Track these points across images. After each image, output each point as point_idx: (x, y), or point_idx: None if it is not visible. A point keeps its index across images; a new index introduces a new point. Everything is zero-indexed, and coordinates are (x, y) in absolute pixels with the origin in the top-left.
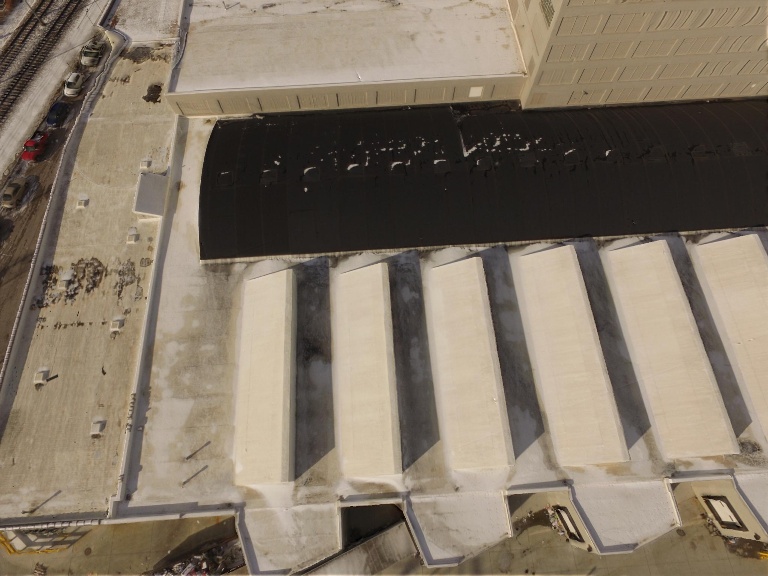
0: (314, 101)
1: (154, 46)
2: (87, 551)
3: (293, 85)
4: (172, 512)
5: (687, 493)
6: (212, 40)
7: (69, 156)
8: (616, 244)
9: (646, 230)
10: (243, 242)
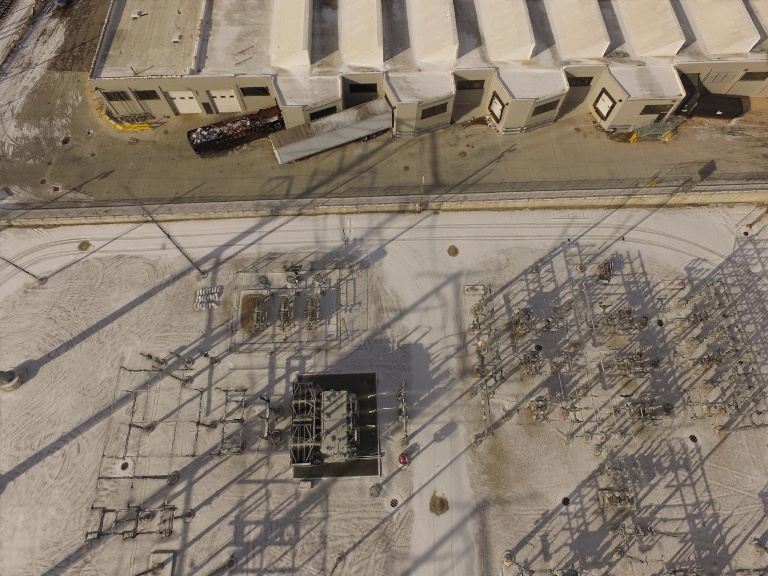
0: None
1: None
2: (166, 132)
3: None
4: None
5: (584, 110)
6: None
7: None
8: None
9: None
10: None
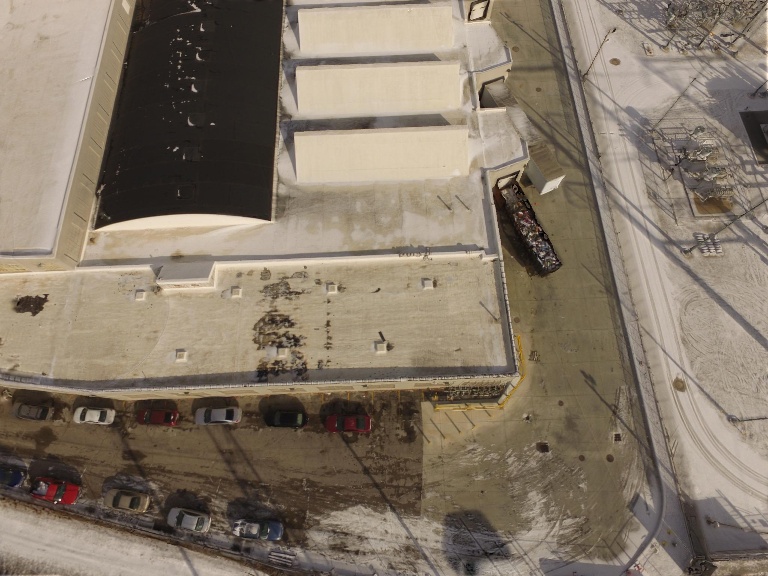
0: (99, 130)
1: None
2: (517, 321)
3: (79, 134)
4: (490, 214)
5: None
6: None
7: (106, 388)
8: None
9: None
10: (258, 182)
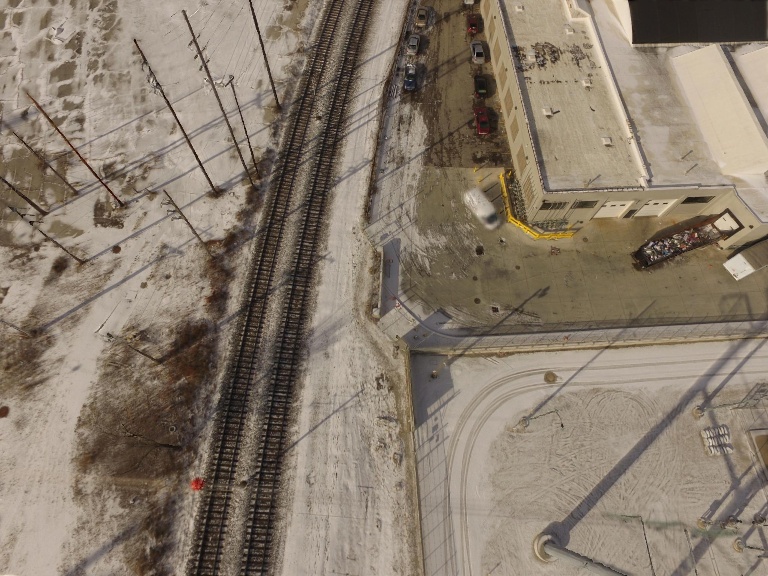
0: None
1: None
2: (585, 240)
3: None
4: None
5: None
6: None
7: None
8: None
9: None
10: (664, 32)
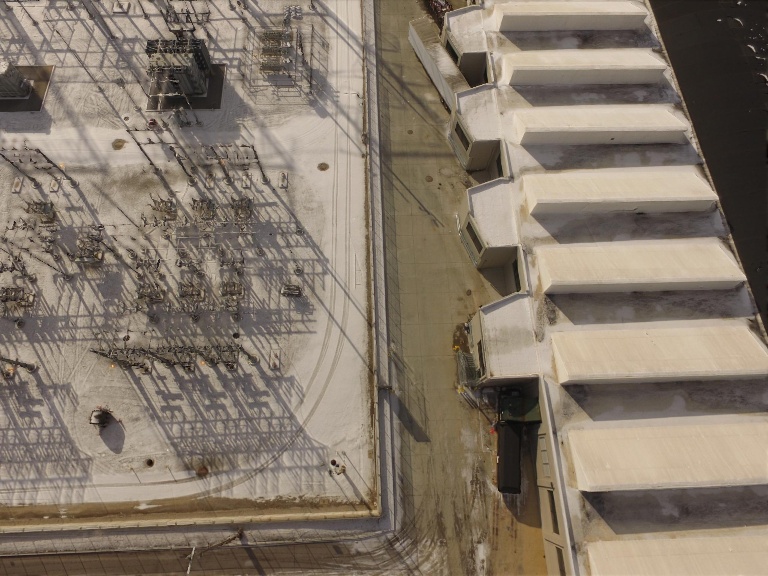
0: None
1: None
2: None
3: None
4: None
5: None
6: None
7: None
8: (729, 253)
9: (753, 281)
10: None
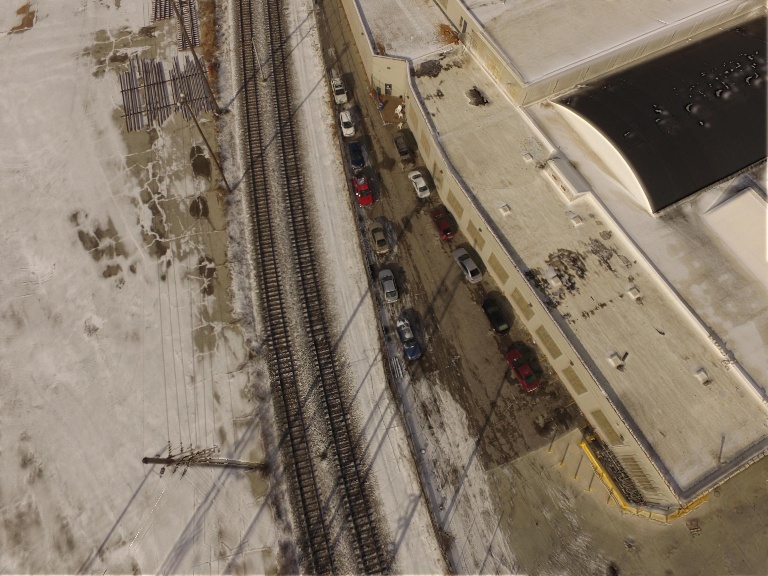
0: (626, 56)
1: (435, 58)
2: (716, 494)
3: (619, 44)
4: None
5: None
6: (513, 30)
7: None
8: None
9: None
10: (679, 185)
